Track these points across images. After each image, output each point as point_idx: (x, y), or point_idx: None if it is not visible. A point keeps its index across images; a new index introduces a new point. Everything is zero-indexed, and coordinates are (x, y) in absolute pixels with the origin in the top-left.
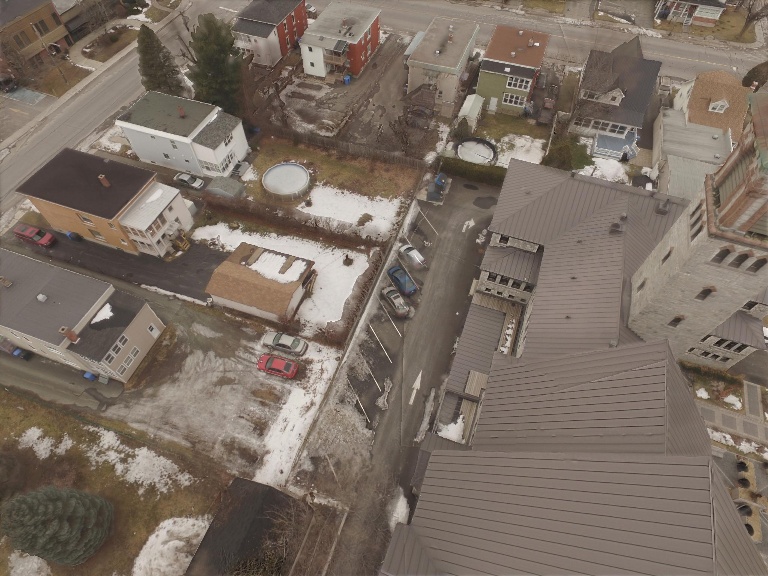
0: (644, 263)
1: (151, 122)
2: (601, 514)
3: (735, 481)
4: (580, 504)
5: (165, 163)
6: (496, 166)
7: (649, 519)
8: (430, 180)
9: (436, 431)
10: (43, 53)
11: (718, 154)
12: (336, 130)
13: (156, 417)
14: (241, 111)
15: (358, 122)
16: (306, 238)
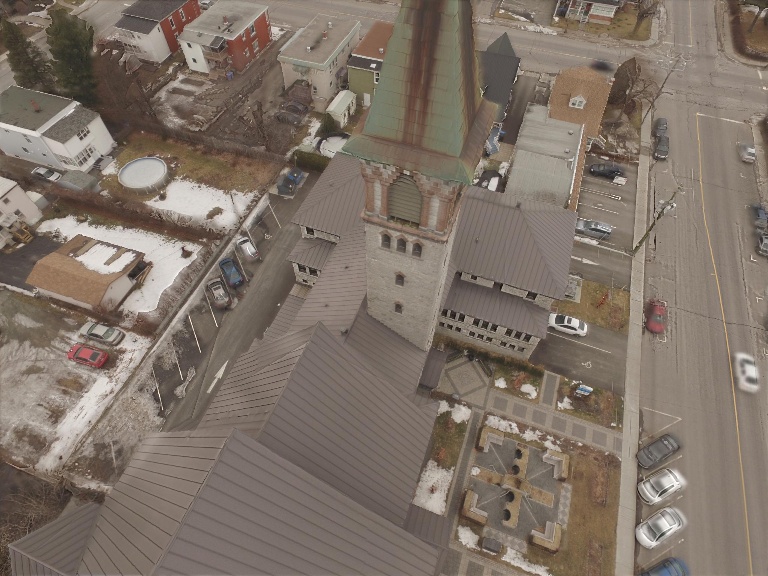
0: None
1: (4, 116)
2: (168, 486)
3: (509, 468)
4: (167, 478)
5: (27, 157)
6: None
7: (180, 489)
8: (287, 174)
9: None
10: None
11: (567, 149)
12: (206, 125)
13: None
14: (106, 106)
15: (231, 117)
16: (151, 231)
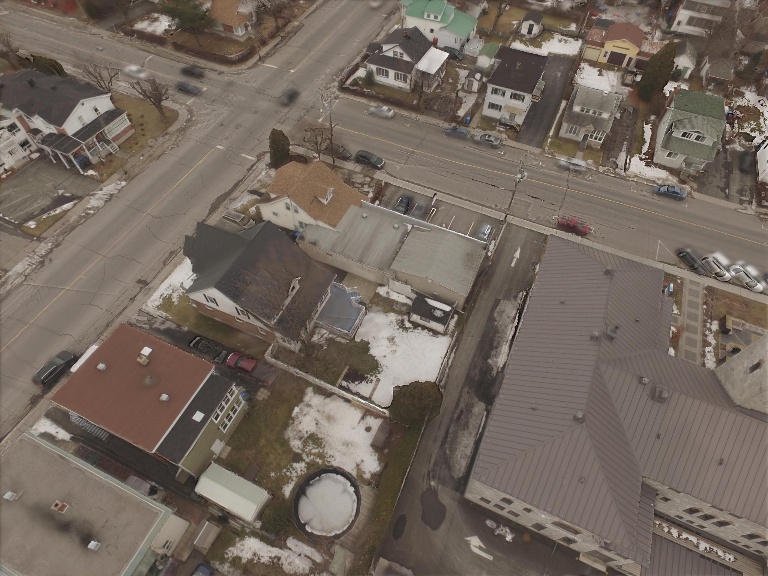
0: (765, 396)
1: None
2: None
3: None
4: None
5: None
6: (383, 481)
7: None
8: None
9: None
10: None
11: (395, 225)
12: None
13: None
14: None
15: None
16: None
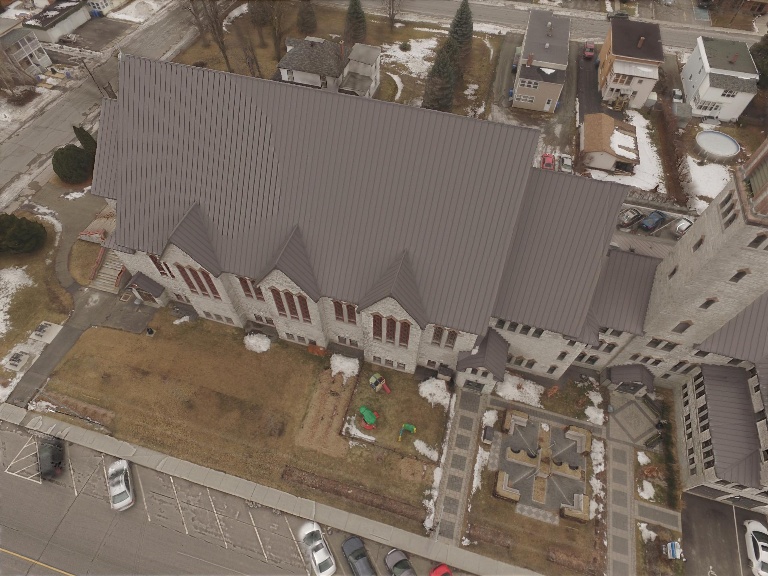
0: None
1: (712, 50)
2: None
3: (557, 459)
4: None
5: None
6: None
7: None
8: None
9: None
10: (749, 2)
11: None
12: None
13: None
14: None
15: None
16: (663, 166)
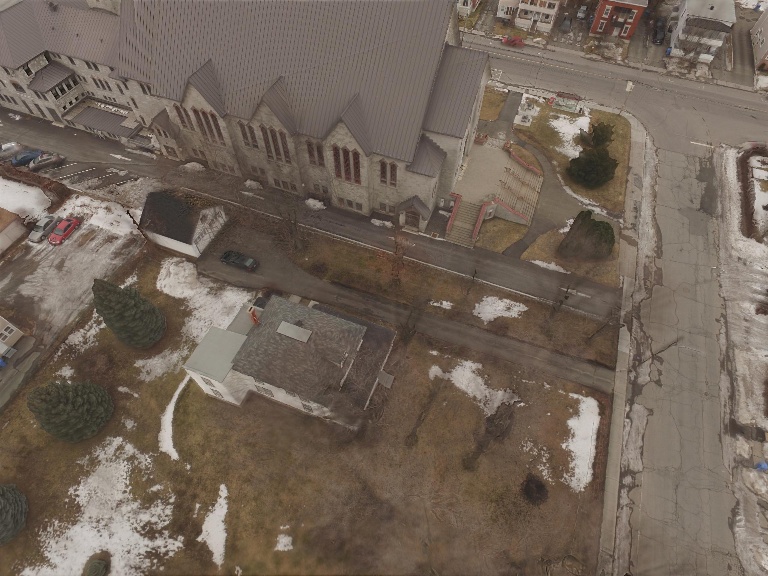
0: None
1: None
2: None
3: None
4: None
5: None
6: None
7: None
8: None
9: (153, 146)
10: None
11: None
12: None
13: (70, 306)
14: None
15: None
16: None
